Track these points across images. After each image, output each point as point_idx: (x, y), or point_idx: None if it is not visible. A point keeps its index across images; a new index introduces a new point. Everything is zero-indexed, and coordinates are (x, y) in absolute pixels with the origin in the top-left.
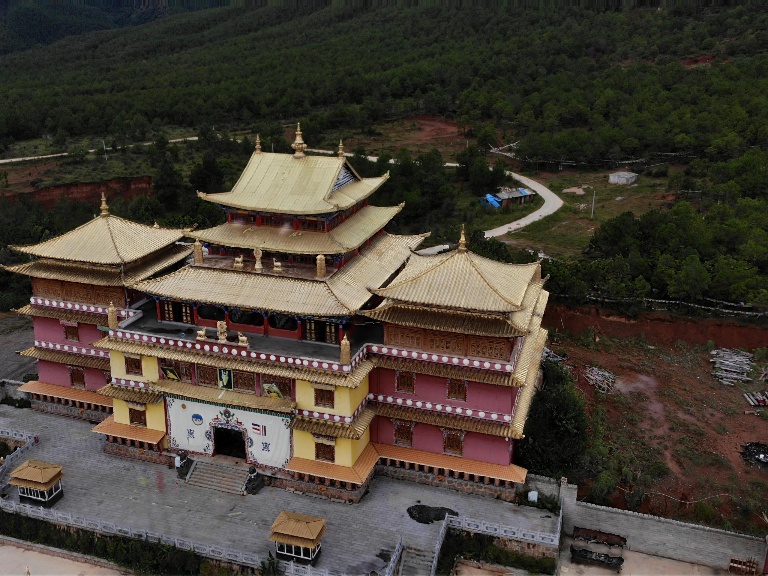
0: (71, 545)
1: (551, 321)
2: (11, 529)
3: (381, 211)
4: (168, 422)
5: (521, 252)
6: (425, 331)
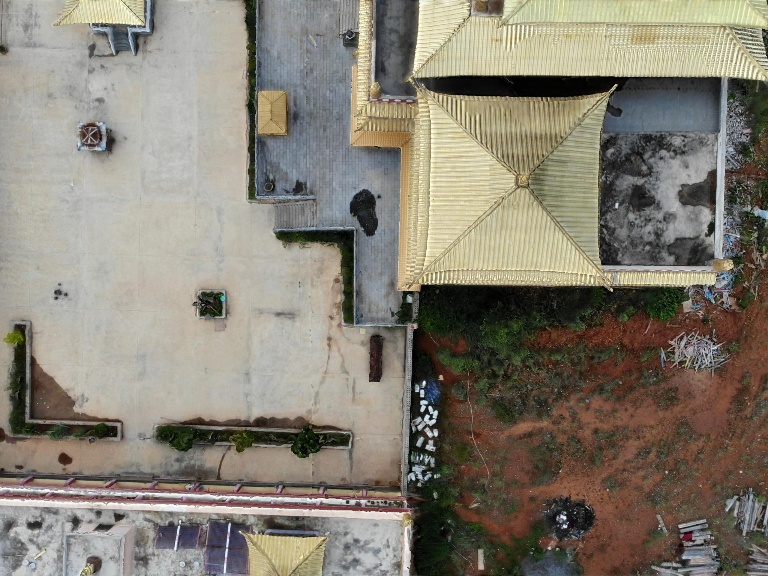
0: None
1: None
2: None
3: (733, 4)
4: None
5: None
6: None
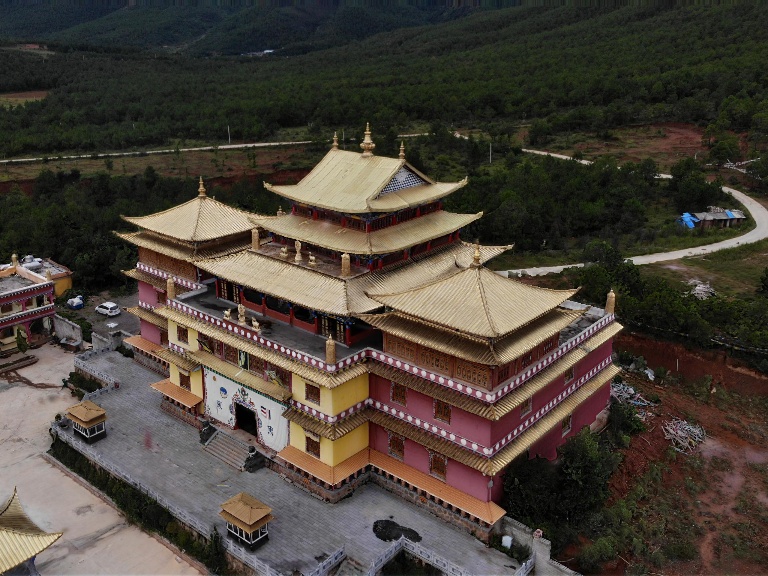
0: (93, 479)
1: (665, 361)
2: (60, 455)
3: (454, 217)
4: (205, 390)
5: (652, 280)
6: (417, 344)
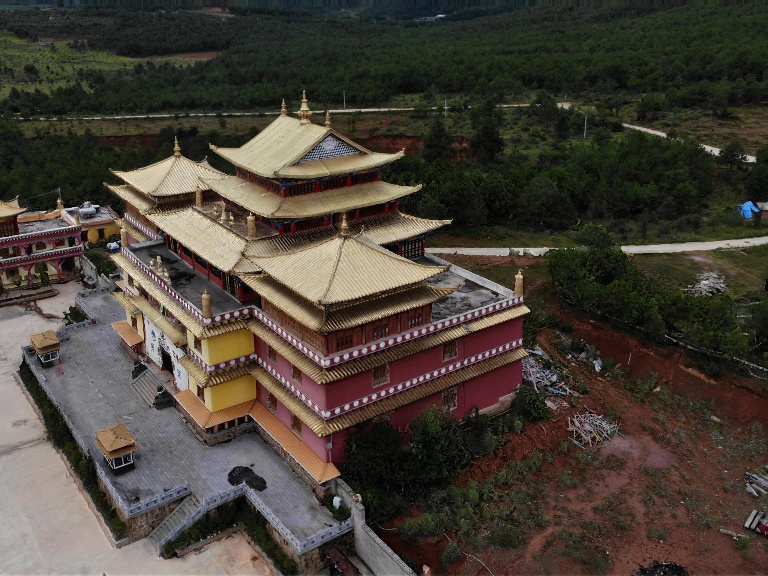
0: None
1: (619, 353)
2: (23, 375)
3: (391, 188)
4: None
5: None
6: None
